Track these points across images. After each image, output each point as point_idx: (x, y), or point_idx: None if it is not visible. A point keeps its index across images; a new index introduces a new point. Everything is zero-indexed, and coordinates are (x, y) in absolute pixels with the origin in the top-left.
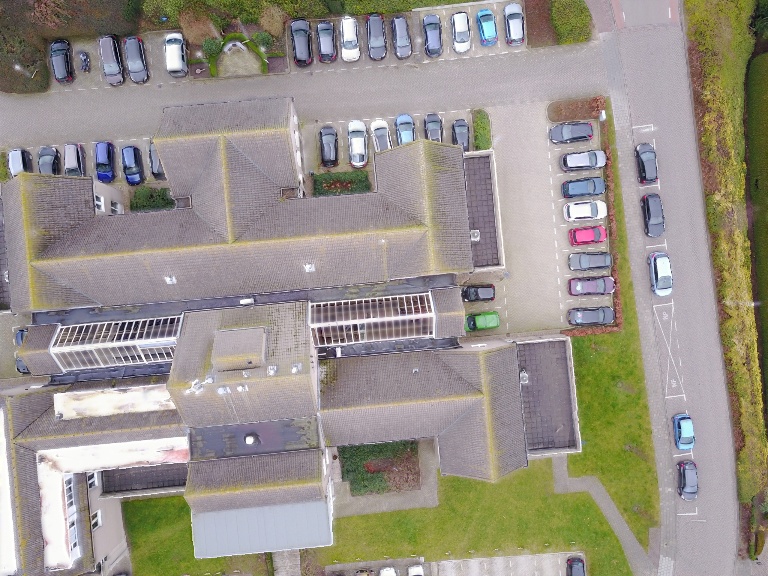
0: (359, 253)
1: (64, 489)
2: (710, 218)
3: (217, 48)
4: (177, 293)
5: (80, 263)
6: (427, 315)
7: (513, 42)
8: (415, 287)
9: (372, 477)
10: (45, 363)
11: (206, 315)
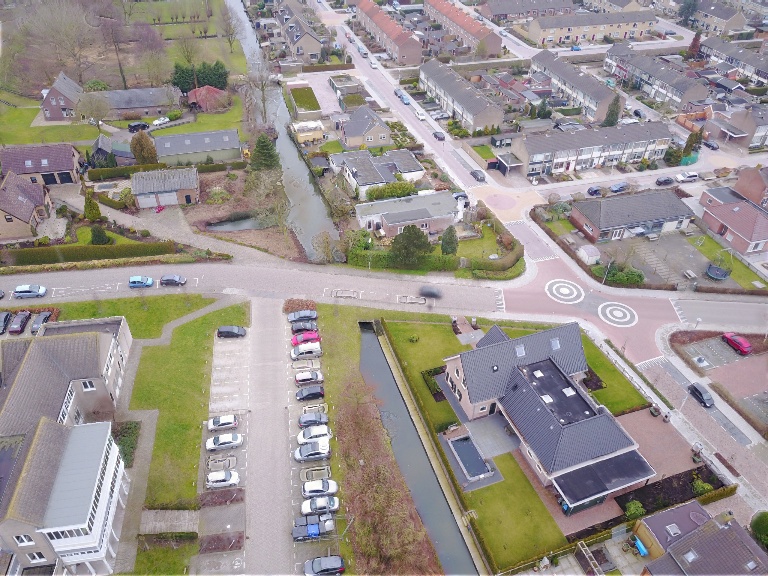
0: None
1: None
2: (6, 273)
3: None
4: None
5: None
6: None
7: None
8: None
9: None
10: None
11: None
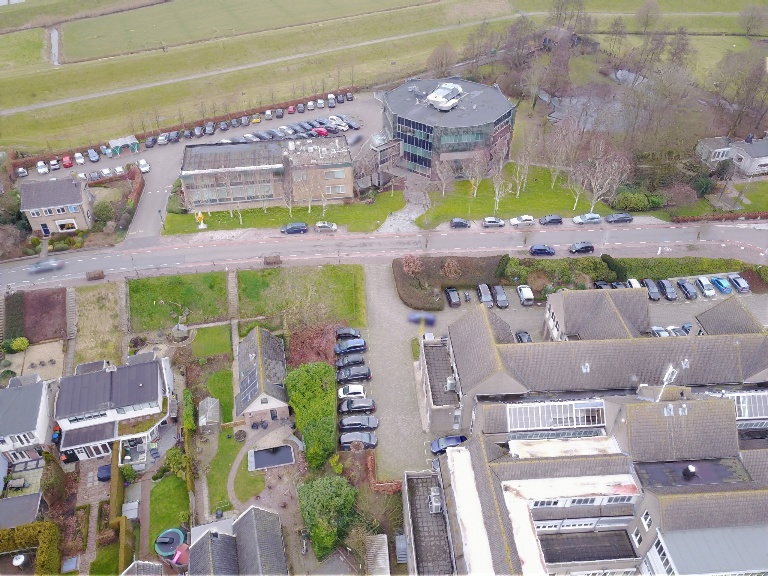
0: (720, 353)
1: (531, 514)
2: None
3: (552, 290)
4: (588, 382)
5: (528, 347)
6: None
7: (743, 289)
8: (765, 388)
9: None
10: (499, 419)
11: (614, 396)
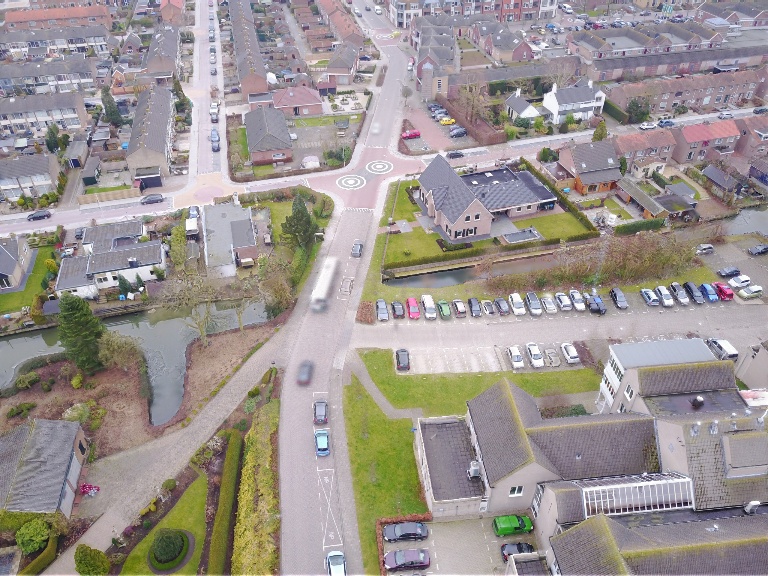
0: None
1: None
2: None
3: None
4: None
5: None
6: (589, 489)
7: None
8: None
9: (571, 415)
10: None
11: None
